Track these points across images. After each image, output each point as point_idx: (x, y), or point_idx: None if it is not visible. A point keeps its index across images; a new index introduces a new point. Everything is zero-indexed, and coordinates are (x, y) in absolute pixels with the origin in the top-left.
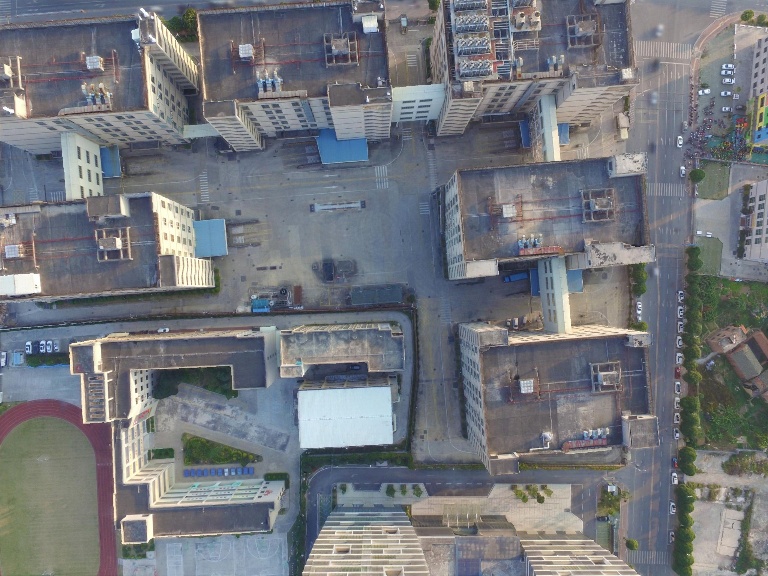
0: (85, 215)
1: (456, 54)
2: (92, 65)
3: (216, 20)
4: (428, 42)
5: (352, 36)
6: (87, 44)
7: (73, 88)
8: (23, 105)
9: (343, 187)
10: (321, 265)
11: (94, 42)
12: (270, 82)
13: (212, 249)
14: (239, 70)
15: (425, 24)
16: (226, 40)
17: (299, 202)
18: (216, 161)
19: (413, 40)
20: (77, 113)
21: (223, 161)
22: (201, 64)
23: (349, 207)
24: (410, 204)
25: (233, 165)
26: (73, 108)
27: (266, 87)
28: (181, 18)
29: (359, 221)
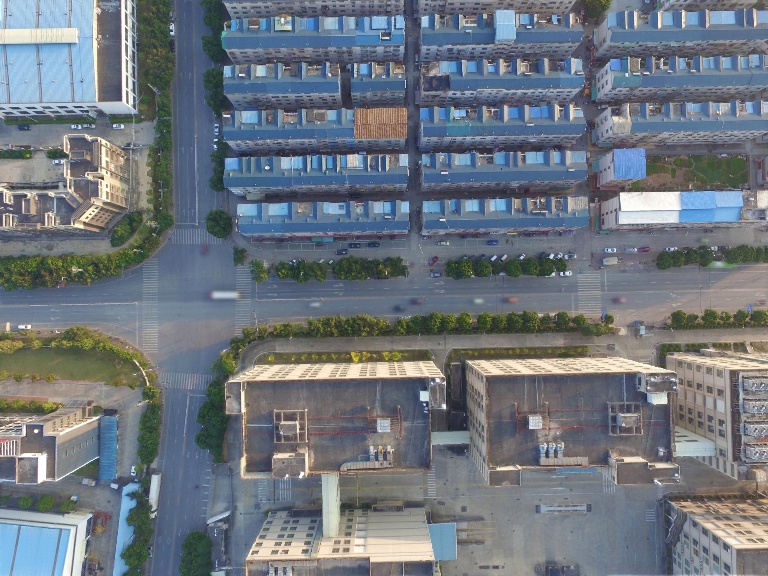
0: (359, 569)
1: (743, 433)
2: (383, 429)
3: (500, 381)
4: (664, 349)
5: (636, 405)
6: (372, 398)
7: (355, 441)
8: (307, 459)
9: (570, 489)
10: (544, 567)
11: (379, 396)
12: (553, 449)
13: (442, 553)
14: (521, 433)
15: (660, 329)
16: (510, 402)
17: (525, 502)
18: (445, 456)
19: (647, 344)
20: (360, 469)
21: (452, 456)
22: (486, 428)
23: (575, 510)
24: (636, 510)
25: (461, 461)
26: (356, 463)
27: (548, 453)
28: (418, 311)
29: (584, 524)
